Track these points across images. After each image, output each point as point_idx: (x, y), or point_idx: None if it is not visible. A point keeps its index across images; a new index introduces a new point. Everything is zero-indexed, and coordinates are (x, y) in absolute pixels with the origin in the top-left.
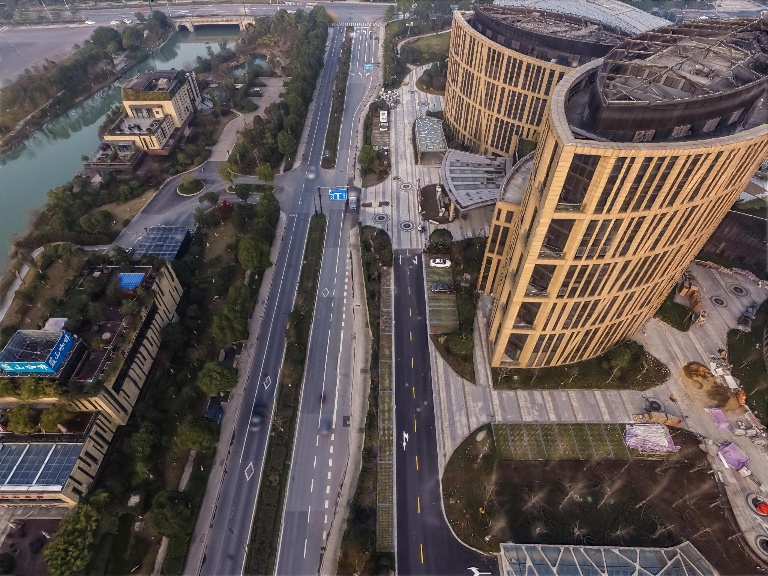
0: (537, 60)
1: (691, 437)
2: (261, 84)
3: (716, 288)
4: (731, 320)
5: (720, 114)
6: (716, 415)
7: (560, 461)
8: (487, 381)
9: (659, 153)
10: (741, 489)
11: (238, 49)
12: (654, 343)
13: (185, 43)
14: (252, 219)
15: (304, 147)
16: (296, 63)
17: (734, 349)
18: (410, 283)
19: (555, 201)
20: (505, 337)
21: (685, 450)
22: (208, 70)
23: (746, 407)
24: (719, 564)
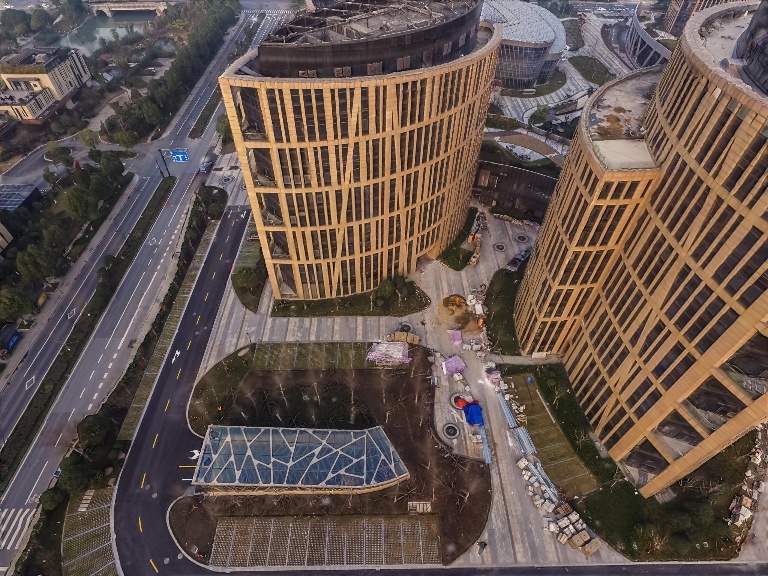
0: None
1: (424, 351)
2: (157, 64)
3: (503, 236)
4: (503, 262)
5: (380, 59)
6: (454, 335)
7: (304, 371)
8: (267, 310)
9: (300, 86)
10: (449, 390)
11: (147, 32)
12: (427, 280)
13: (104, 28)
14: None
15: (178, 120)
16: (189, 44)
17: (494, 284)
18: (231, 233)
19: (239, 131)
20: (270, 268)
21: (415, 361)
22: (111, 51)
23: (484, 329)
24: (403, 444)
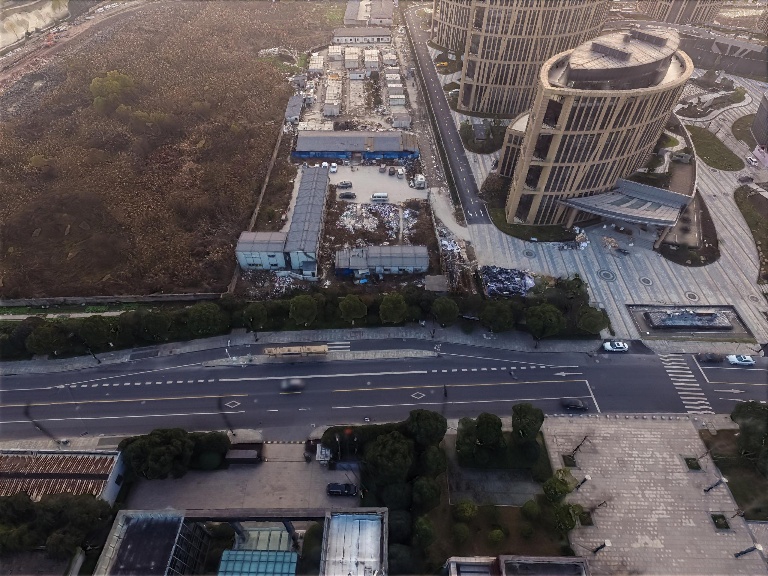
0: None
1: None
2: None
3: None
4: None
5: None
6: None
7: None
8: None
9: None
10: None
11: None
12: None
13: None
14: None
15: None
16: None
17: None
18: None
19: None
20: None
21: None
22: None
23: None
24: None
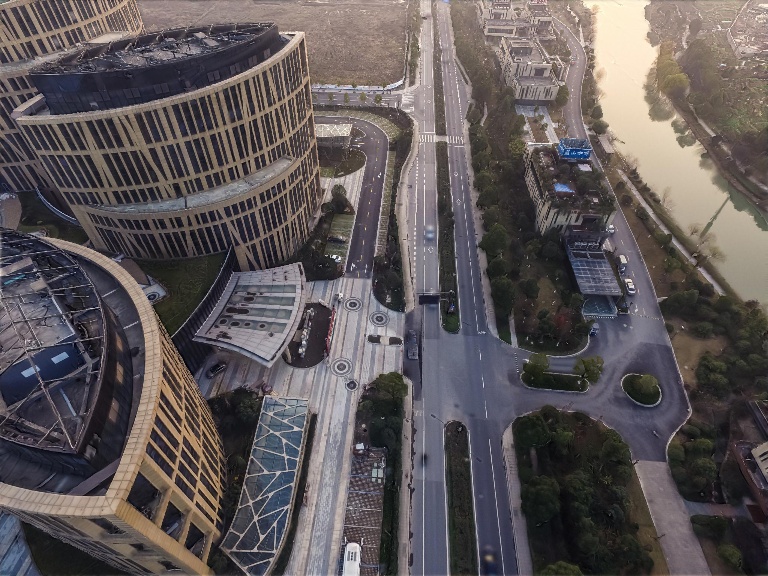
0: (122, 271)
1: None
2: None
3: None
4: None
5: None
6: None
7: None
8: (328, 192)
9: None
10: None
11: None
12: None
13: None
14: (525, 319)
15: (511, 495)
16: None
17: None
18: (362, 248)
19: None
20: None
21: None
22: None
23: None
24: None
